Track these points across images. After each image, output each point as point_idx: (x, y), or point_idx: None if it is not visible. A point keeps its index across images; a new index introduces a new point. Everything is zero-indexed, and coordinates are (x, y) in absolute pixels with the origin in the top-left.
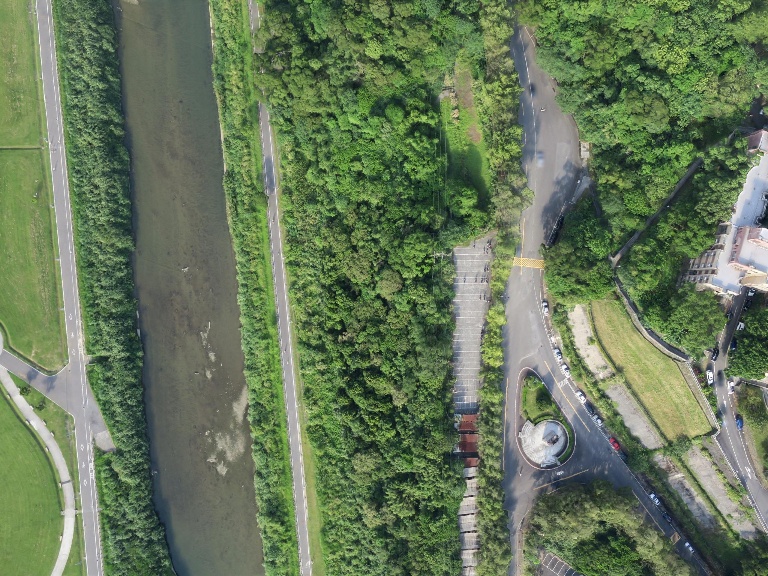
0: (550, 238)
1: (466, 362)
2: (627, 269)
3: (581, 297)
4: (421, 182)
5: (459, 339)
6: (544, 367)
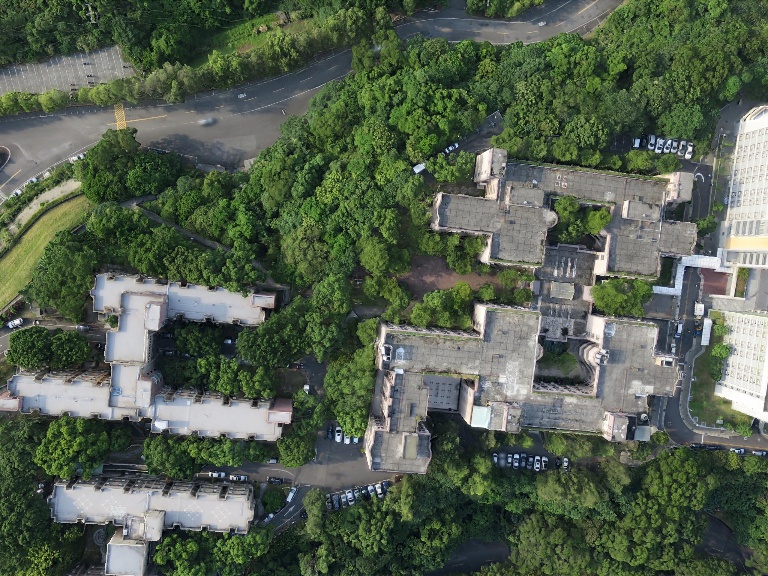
0: (154, 148)
1: (1, 85)
2: (112, 204)
3: (83, 176)
4: (180, 1)
5: (24, 72)
6: (14, 170)
